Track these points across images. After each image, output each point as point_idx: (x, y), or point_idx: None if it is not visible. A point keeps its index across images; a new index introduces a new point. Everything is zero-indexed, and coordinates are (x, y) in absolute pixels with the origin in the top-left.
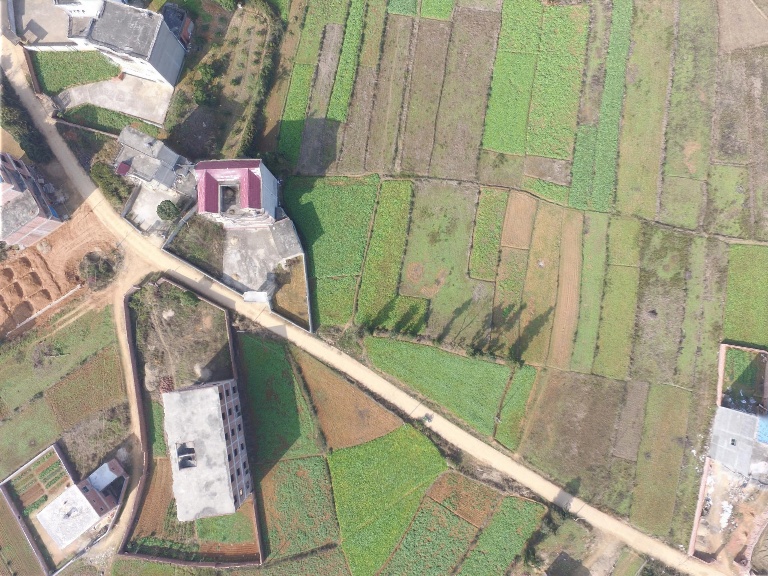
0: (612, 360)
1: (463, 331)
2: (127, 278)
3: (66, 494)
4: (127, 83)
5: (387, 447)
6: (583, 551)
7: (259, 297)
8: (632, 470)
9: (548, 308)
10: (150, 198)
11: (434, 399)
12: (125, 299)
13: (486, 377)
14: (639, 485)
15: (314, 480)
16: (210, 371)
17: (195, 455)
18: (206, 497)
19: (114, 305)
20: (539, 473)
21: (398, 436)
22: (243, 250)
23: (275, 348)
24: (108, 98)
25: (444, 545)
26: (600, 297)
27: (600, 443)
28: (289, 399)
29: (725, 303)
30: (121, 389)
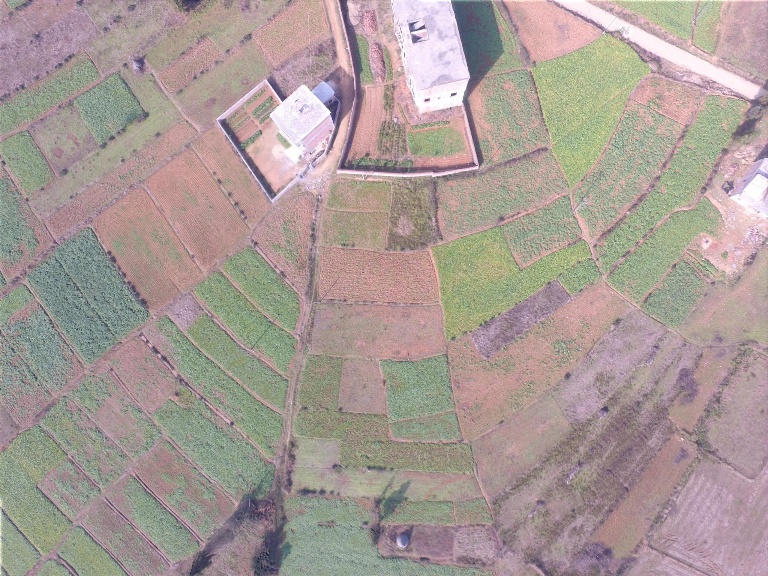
0: None
1: None
2: None
3: (296, 93)
4: None
5: (589, 55)
6: None
7: None
8: None
9: None
10: None
11: (631, 9)
12: None
13: None
14: None
15: (520, 91)
16: None
17: (426, 30)
18: (440, 66)
19: None
20: (738, 73)
21: (599, 45)
22: None
23: None
24: None
25: (652, 142)
26: None
27: None
28: (489, 20)
29: None
30: None
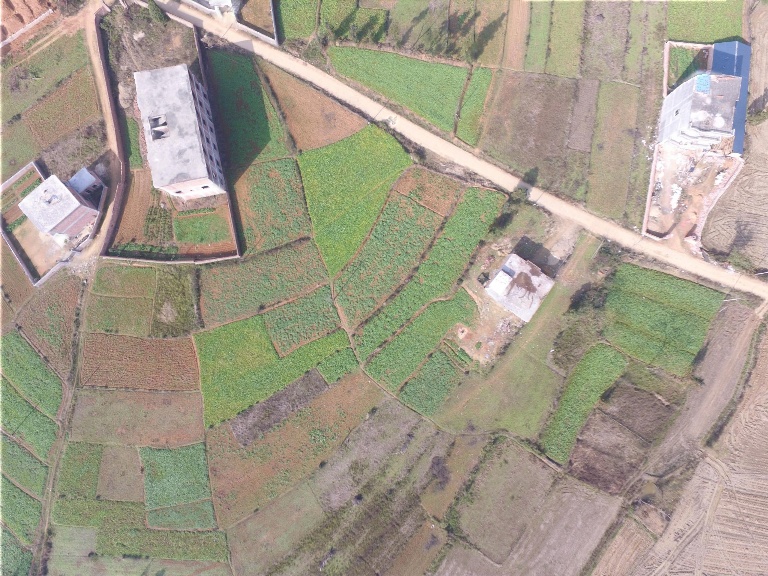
0: (563, 60)
1: (421, 38)
2: (97, 3)
3: (46, 183)
4: None
5: (354, 145)
6: (543, 235)
7: (224, 1)
8: (586, 160)
9: (501, 14)
10: None
11: (396, 100)
12: (96, 19)
13: (445, 78)
14: (594, 174)
15: (285, 180)
16: None
17: (167, 126)
18: (179, 164)
19: (86, 29)
20: (499, 166)
21: (364, 135)
22: None
23: (243, 61)
24: None
25: (412, 233)
26: (550, 3)
27: (555, 136)
28: (258, 107)
29: (667, 6)
30: (96, 108)
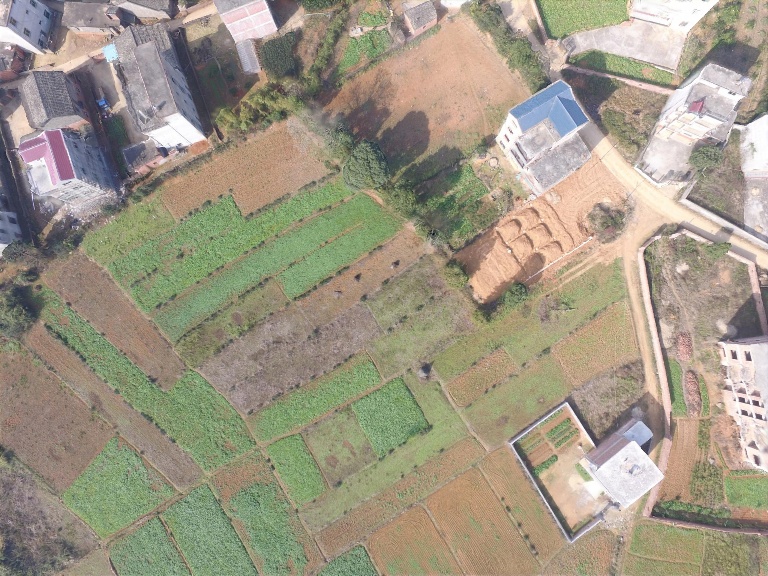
0: None
1: None
2: (637, 230)
3: (626, 451)
4: (635, 28)
5: None
6: None
7: None
8: None
9: None
10: (662, 147)
11: None
12: (643, 251)
13: None
14: None
15: None
16: (735, 327)
17: None
18: None
19: (624, 258)
20: None
21: None
22: (765, 201)
23: None
24: (616, 44)
25: None
26: None
27: None
28: None
29: None
30: None
